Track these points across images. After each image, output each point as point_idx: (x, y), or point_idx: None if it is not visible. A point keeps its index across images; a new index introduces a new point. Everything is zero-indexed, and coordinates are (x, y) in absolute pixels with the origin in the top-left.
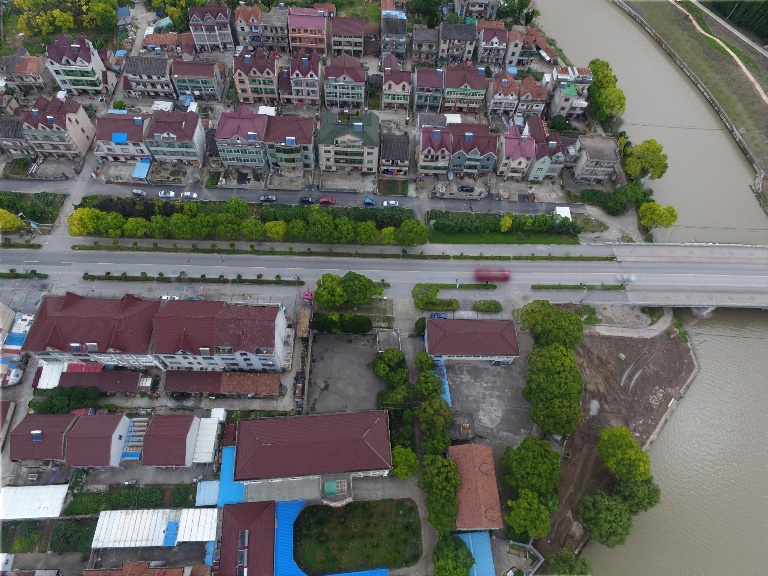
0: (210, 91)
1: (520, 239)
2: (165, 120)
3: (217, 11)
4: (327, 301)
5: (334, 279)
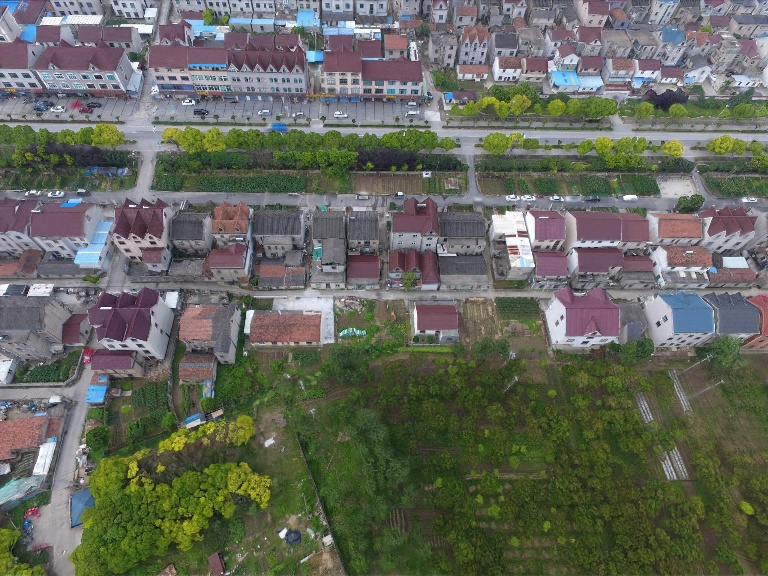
0: None
1: None
2: (6, 212)
3: None
4: None
5: None
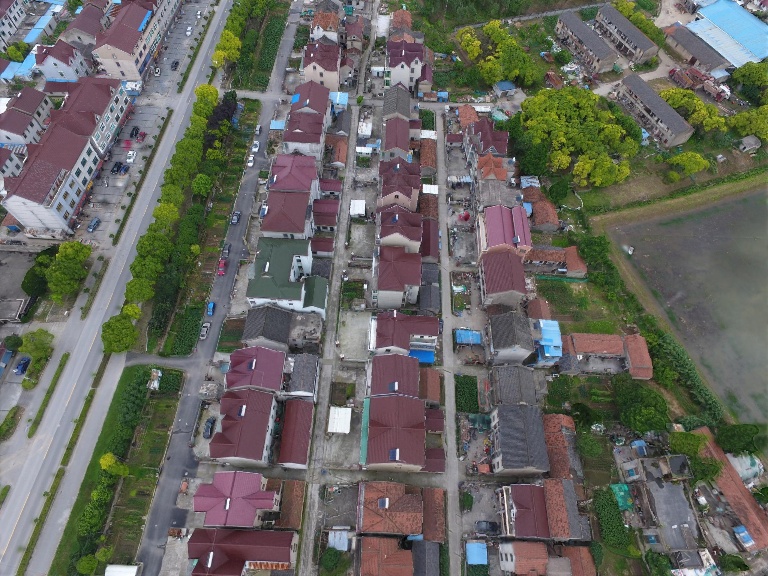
0: None
1: (91, 486)
2: (305, 119)
3: (488, 140)
4: None
5: (67, 250)
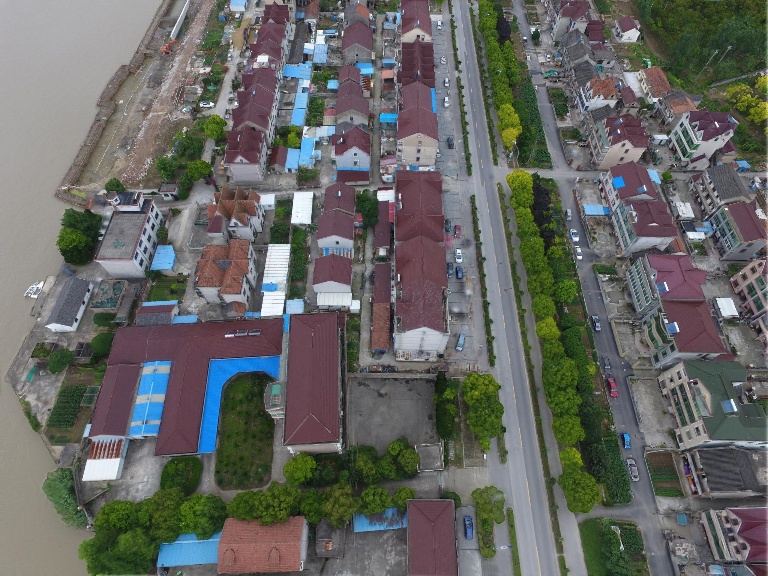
0: (727, 245)
1: None
2: (653, 209)
3: None
4: (466, 385)
5: (488, 387)
